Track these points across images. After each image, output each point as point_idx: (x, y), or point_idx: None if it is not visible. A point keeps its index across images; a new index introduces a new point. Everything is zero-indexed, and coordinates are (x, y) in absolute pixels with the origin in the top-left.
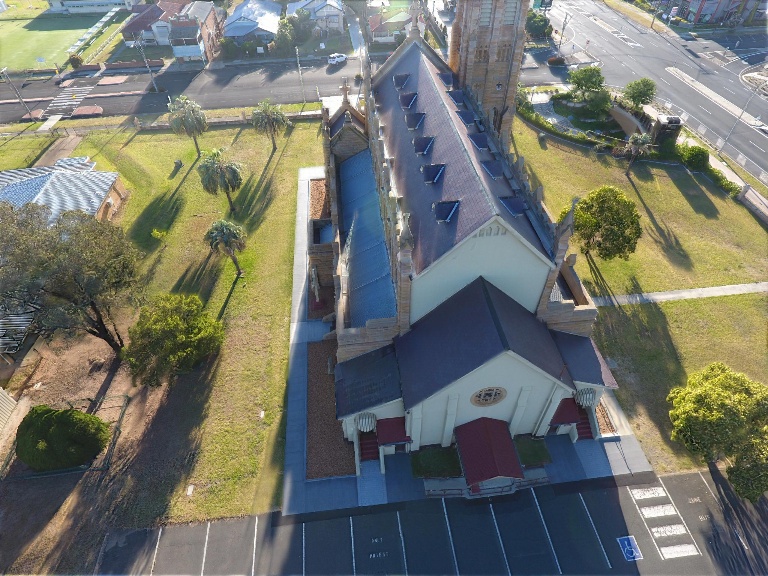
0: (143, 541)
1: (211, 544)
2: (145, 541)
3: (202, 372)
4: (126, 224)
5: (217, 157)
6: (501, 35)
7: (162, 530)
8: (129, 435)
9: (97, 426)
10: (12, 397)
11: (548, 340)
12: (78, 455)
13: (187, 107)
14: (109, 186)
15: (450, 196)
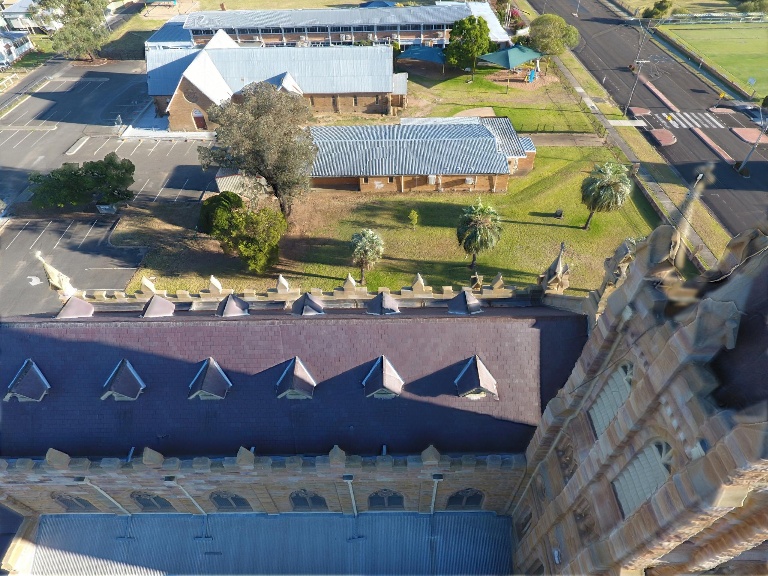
0: (134, 262)
1: (109, 291)
2: (133, 263)
3: (248, 271)
4: (449, 200)
5: (483, 213)
6: (599, 491)
7: (135, 269)
8: (214, 244)
9: (219, 225)
10: (265, 189)
11: (1, 514)
12: (203, 223)
13: (606, 177)
14: (485, 172)
15: (82, 317)
